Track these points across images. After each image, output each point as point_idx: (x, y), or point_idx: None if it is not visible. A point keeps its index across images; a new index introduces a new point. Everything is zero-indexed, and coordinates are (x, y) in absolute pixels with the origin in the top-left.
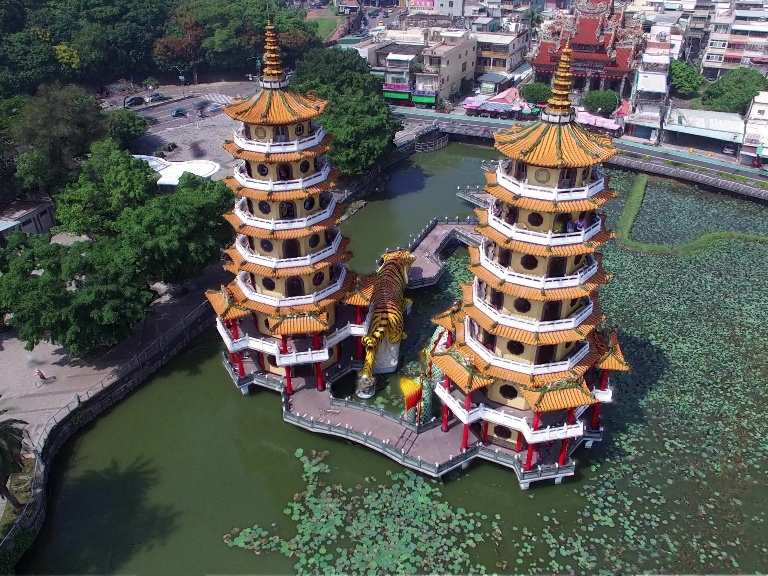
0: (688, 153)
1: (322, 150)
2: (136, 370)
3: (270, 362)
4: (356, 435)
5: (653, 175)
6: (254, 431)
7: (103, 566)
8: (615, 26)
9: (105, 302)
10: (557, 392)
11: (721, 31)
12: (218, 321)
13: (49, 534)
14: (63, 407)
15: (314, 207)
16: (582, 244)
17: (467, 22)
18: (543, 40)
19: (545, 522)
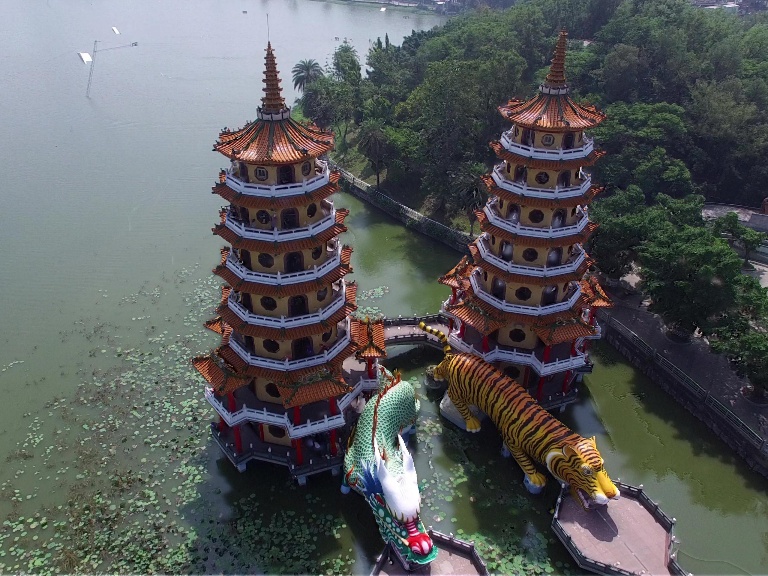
0: None
1: None
2: None
3: None
4: None
5: None
6: None
7: (419, 261)
8: None
9: None
10: None
11: None
12: None
13: None
14: None
15: None
16: None
17: None
18: None
19: None
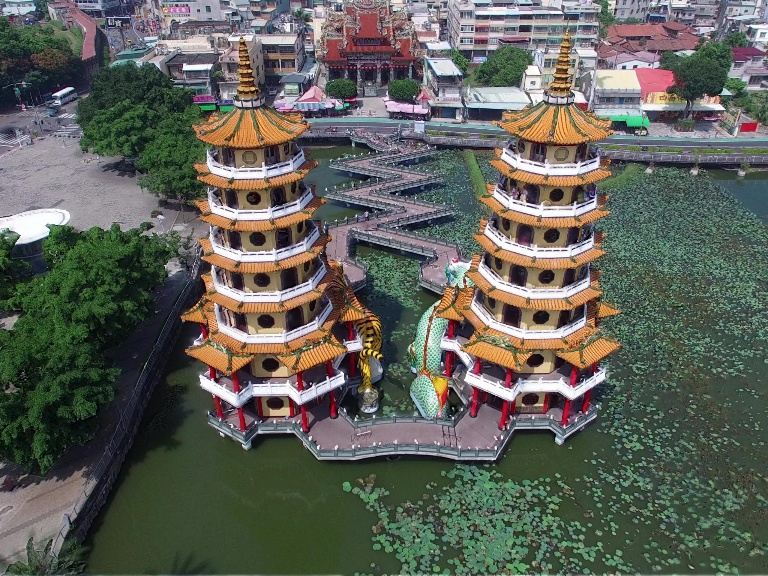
0: (492, 126)
1: (312, 166)
2: (110, 464)
3: (270, 406)
4: (407, 448)
5: (476, 149)
6: (258, 486)
7: None
8: (392, 19)
9: (71, 394)
10: (590, 346)
11: (466, 17)
12: (203, 378)
13: None
14: (57, 536)
15: (303, 228)
16: (596, 209)
17: (243, 26)
18: (328, 37)
19: (595, 465)
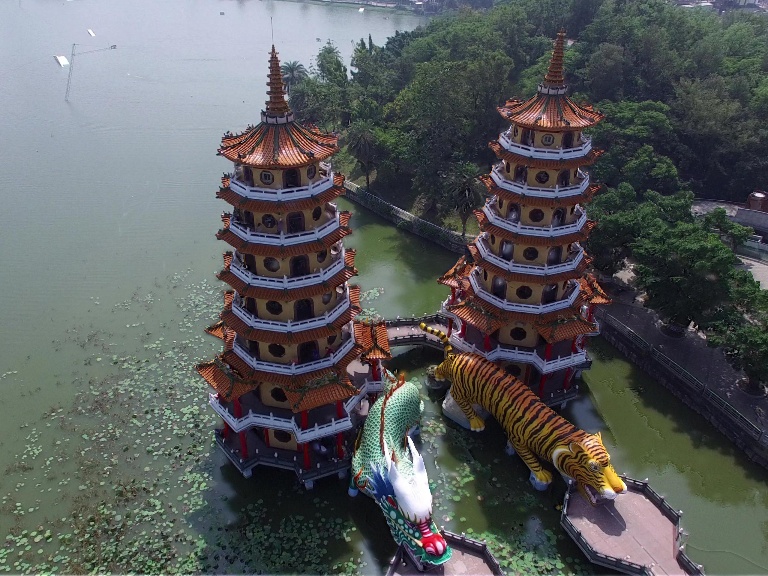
0: None
1: None
2: None
3: None
4: None
5: None
6: None
7: None
8: None
9: None
10: None
11: None
12: None
13: (451, 255)
14: None
15: None
16: None
17: None
18: None
19: None
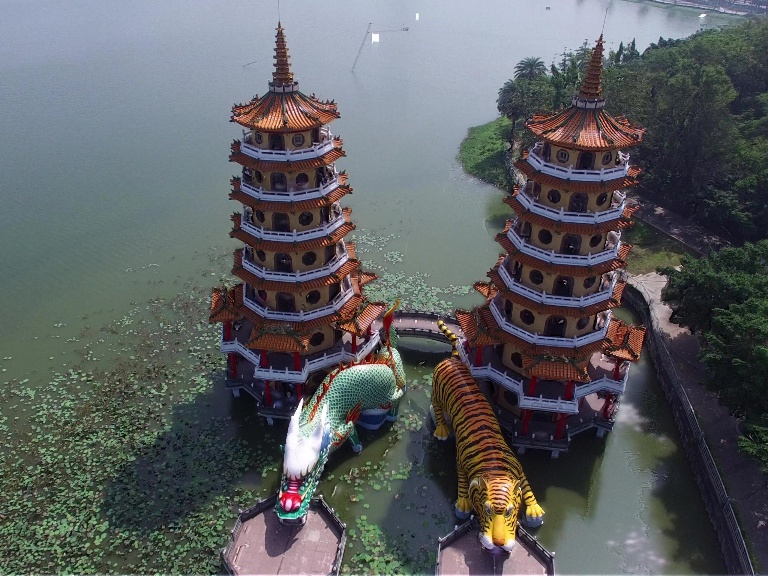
0: None
1: None
2: None
3: None
4: None
5: None
6: None
7: None
8: None
9: None
10: None
11: None
12: None
13: None
14: None
15: None
16: None
17: None
18: None
19: None
